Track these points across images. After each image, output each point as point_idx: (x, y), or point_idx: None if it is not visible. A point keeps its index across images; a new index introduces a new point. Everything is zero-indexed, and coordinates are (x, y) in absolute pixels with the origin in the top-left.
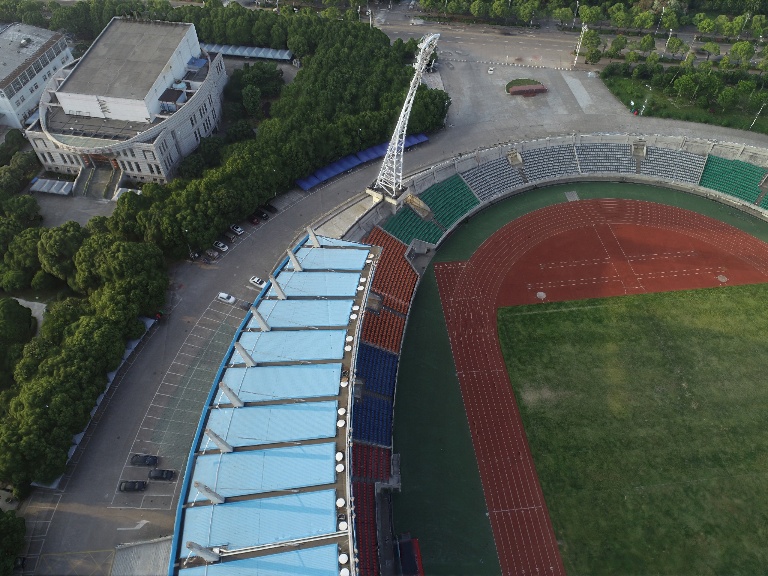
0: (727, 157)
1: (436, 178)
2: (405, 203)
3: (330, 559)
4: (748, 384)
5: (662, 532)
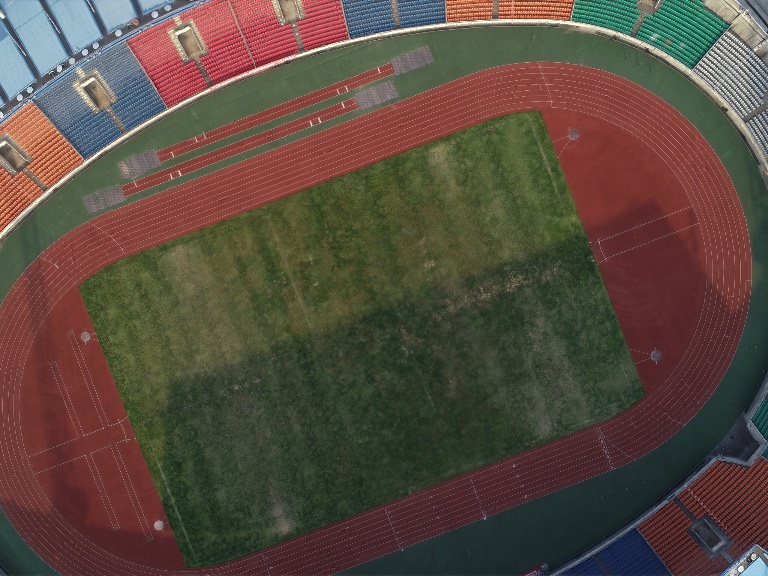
0: None
1: None
2: None
3: None
4: (221, 329)
5: (382, 415)
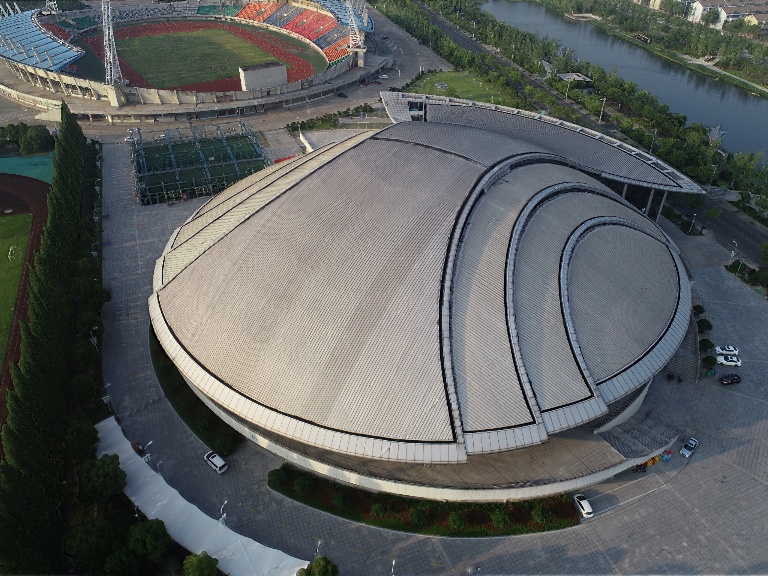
0: (206, 5)
1: (77, 16)
2: (63, 20)
3: (31, 25)
4: None
5: None
